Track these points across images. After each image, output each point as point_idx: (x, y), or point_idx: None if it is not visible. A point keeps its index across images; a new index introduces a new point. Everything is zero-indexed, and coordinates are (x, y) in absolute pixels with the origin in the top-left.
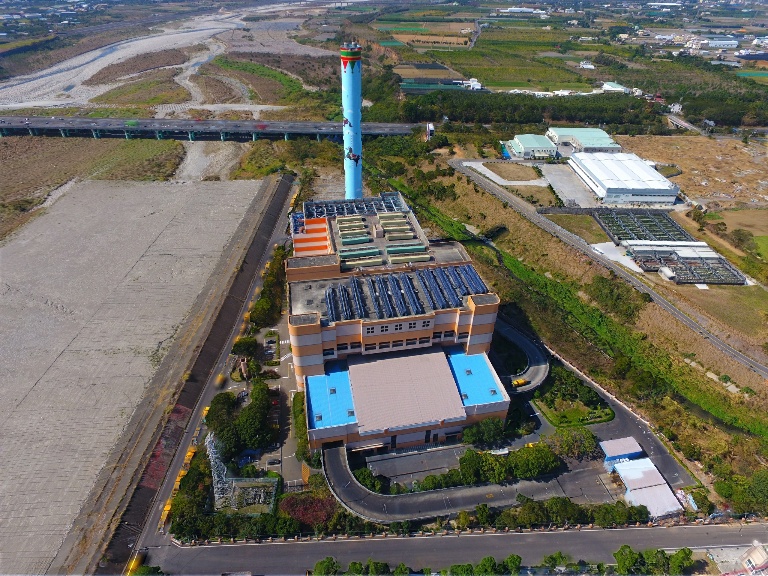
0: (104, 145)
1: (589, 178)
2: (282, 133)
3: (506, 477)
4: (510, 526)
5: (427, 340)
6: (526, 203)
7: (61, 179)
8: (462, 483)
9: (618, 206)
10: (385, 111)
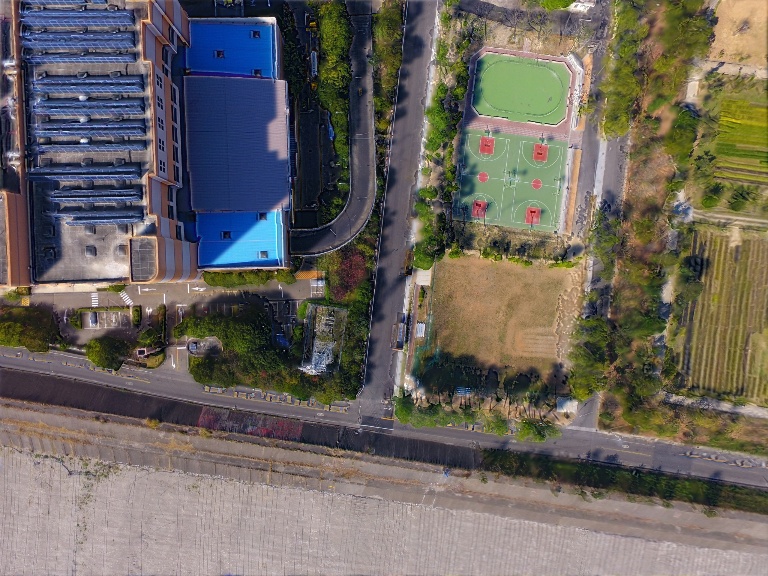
0: None
1: None
2: None
3: None
4: None
5: (173, 91)
6: None
7: None
8: None
9: None
10: None
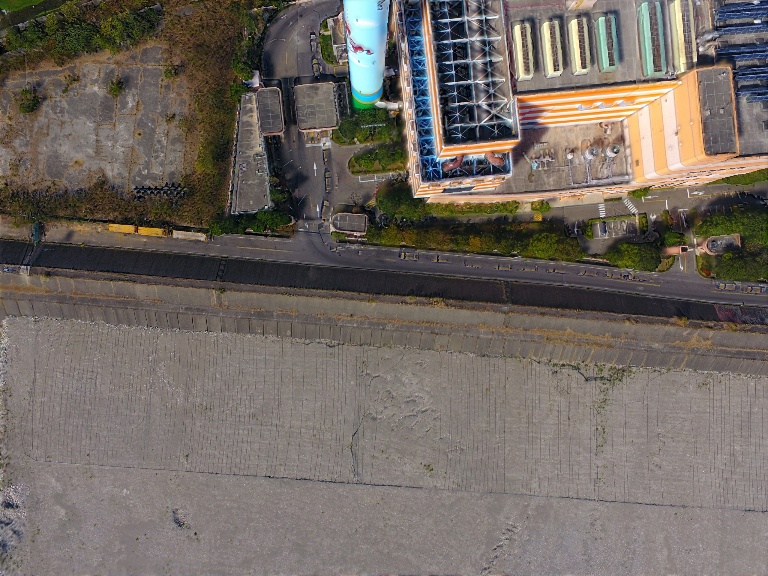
0: None
1: None
2: None
3: None
4: None
5: None
6: None
7: None
8: None
9: None
10: None
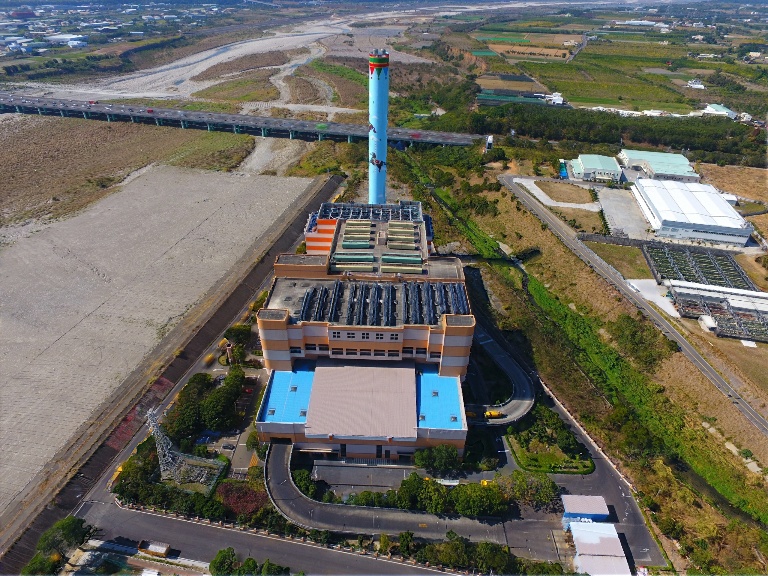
0: (188, 135)
1: (648, 207)
2: (346, 135)
3: (448, 510)
4: (430, 561)
5: (396, 354)
6: (568, 227)
7: (142, 162)
8: (396, 506)
9: (674, 241)
10: (453, 120)
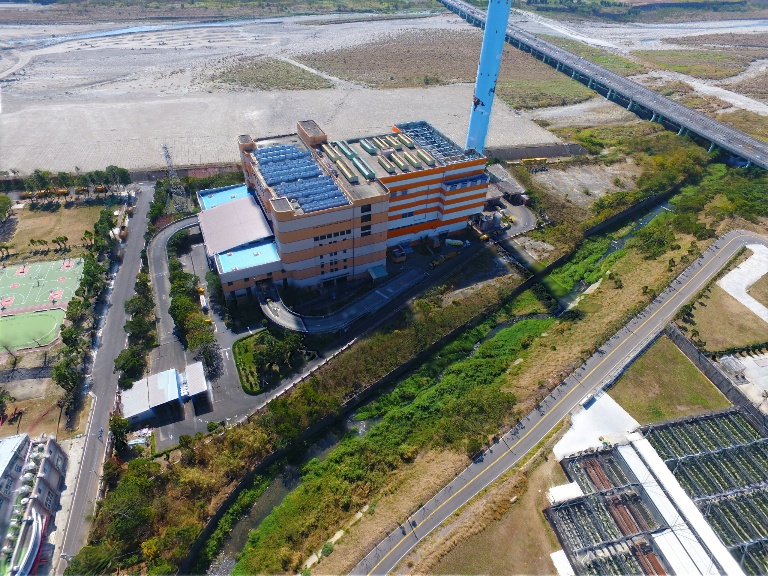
0: (548, 75)
1: None
2: (680, 125)
3: None
4: None
5: None
6: None
7: None
8: None
9: None
10: None
